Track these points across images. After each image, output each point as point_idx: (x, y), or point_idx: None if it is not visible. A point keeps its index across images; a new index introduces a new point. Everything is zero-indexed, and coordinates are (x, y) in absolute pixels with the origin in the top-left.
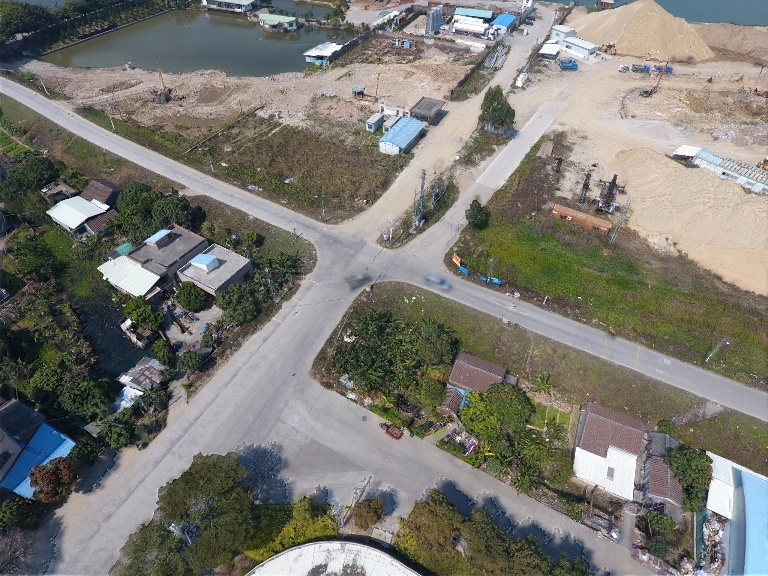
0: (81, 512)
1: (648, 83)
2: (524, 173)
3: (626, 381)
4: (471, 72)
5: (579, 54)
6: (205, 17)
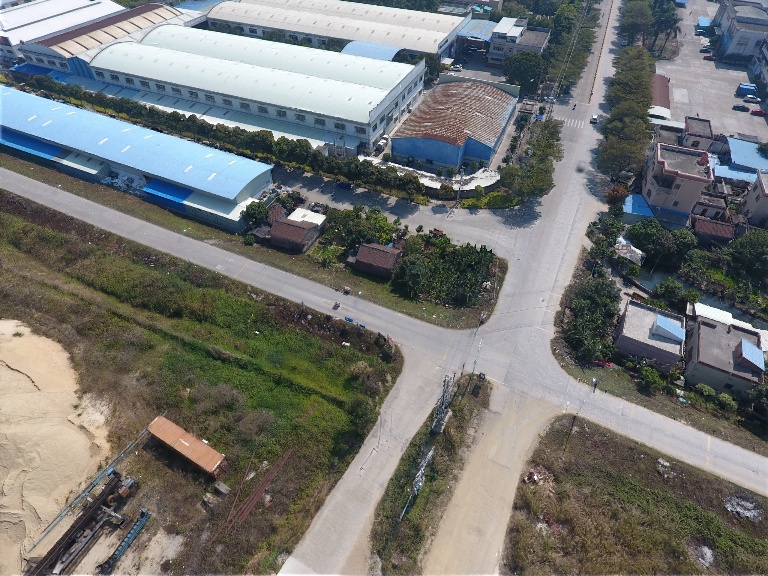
0: (596, 206)
1: None
2: None
3: None
4: None
5: None
6: None
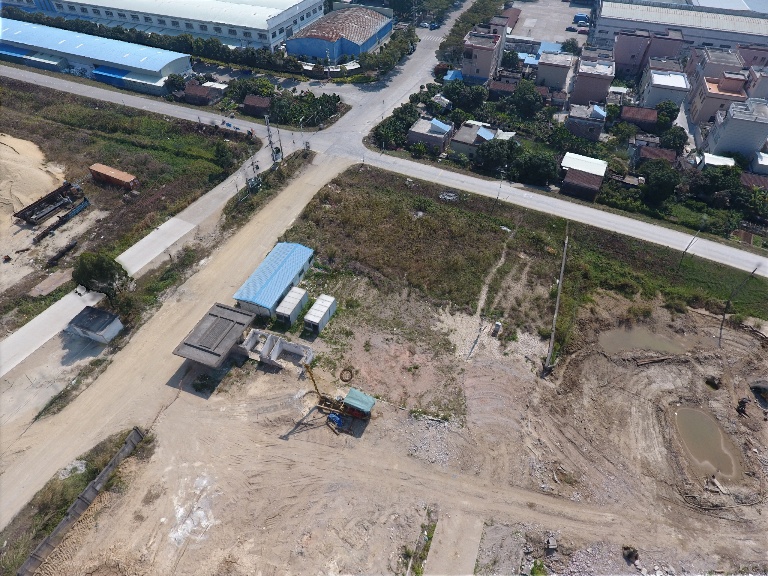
0: None
1: None
2: None
3: None
4: None
5: None
6: None
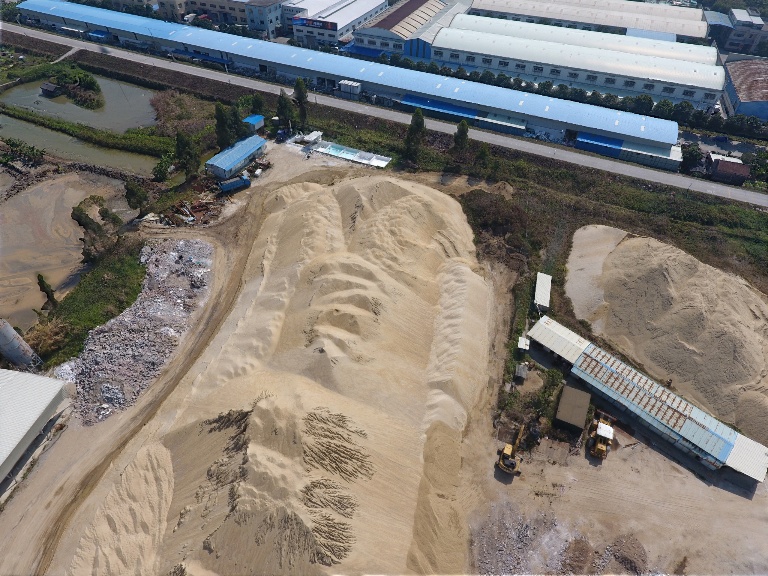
0: None
1: None
2: None
3: None
4: None
5: None
6: None
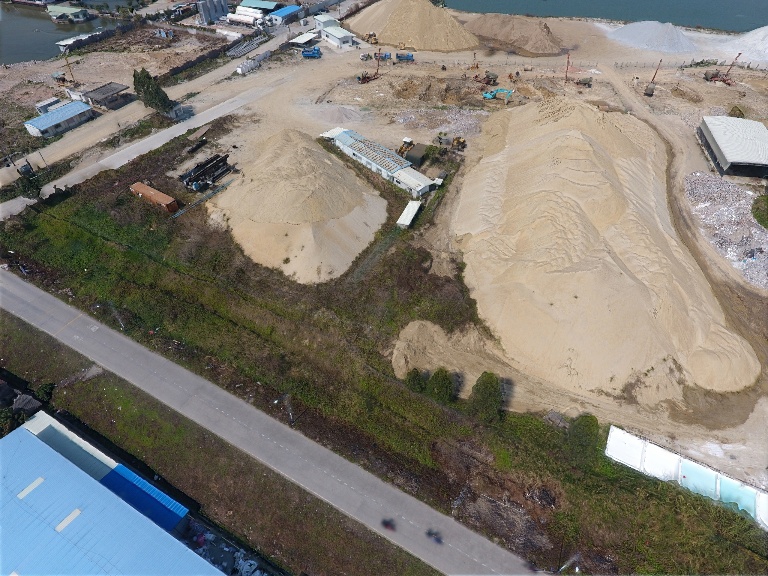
0: None
1: (379, 70)
2: (157, 154)
3: (37, 346)
4: (200, 60)
5: (335, 43)
6: (14, 10)
